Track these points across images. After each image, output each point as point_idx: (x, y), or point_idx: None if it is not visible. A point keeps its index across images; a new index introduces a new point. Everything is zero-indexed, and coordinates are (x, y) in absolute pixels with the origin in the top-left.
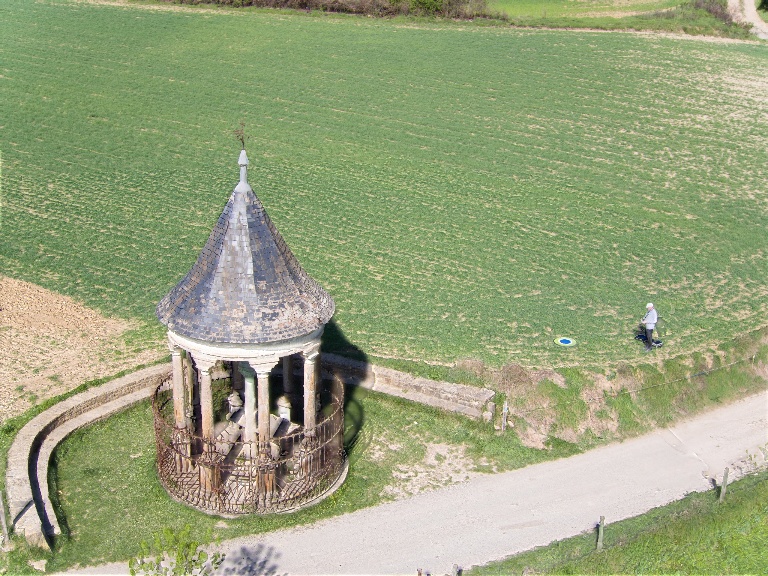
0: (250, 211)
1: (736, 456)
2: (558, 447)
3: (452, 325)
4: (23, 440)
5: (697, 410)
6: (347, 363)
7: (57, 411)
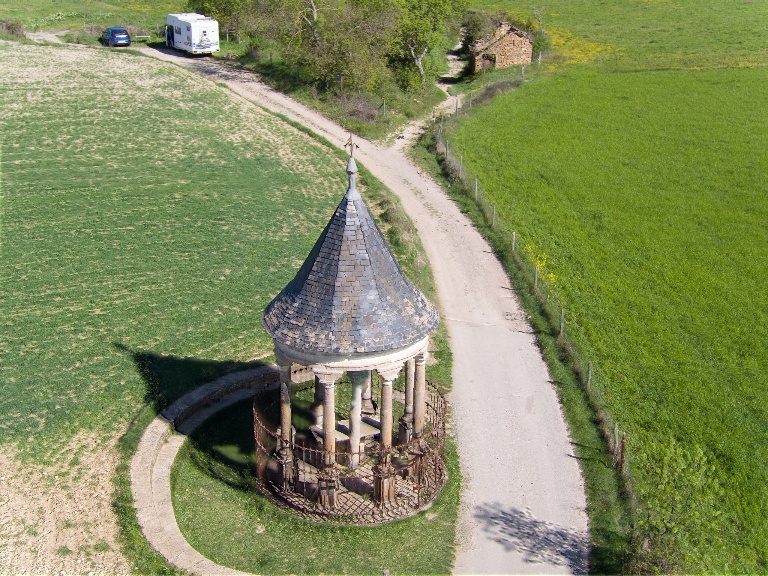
0: (370, 215)
1: (499, 314)
2: (442, 357)
3: (246, 315)
4: (206, 569)
5: (435, 301)
6: (256, 373)
7: (162, 536)
